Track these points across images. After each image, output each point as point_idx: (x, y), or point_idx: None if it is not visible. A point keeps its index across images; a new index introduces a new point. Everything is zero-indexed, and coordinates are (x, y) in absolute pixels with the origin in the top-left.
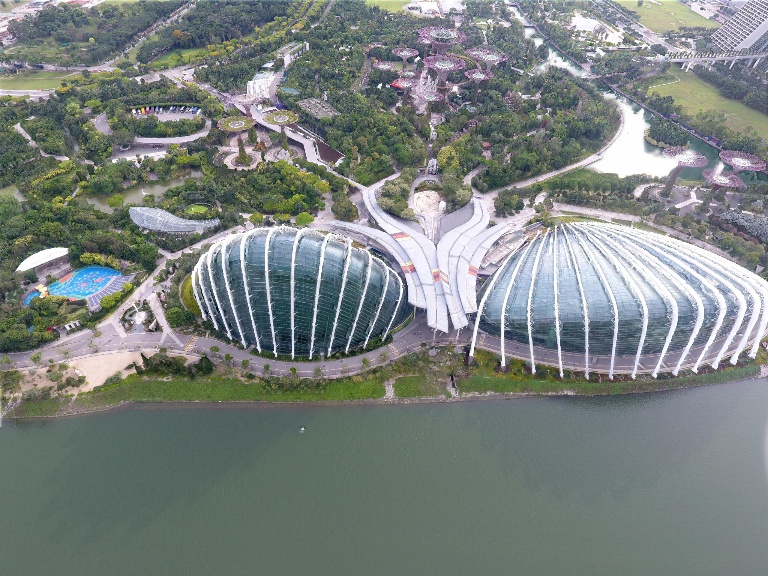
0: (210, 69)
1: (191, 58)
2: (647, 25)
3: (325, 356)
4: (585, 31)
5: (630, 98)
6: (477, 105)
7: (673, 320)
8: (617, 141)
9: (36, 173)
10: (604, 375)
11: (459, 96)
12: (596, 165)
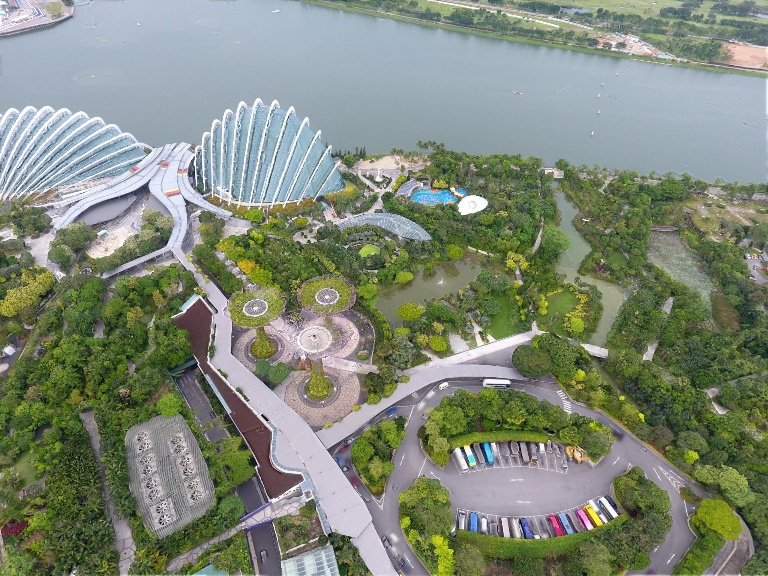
0: None
1: None
2: None
3: None
4: None
5: None
6: None
7: None
8: None
9: None
10: None
11: None
12: None
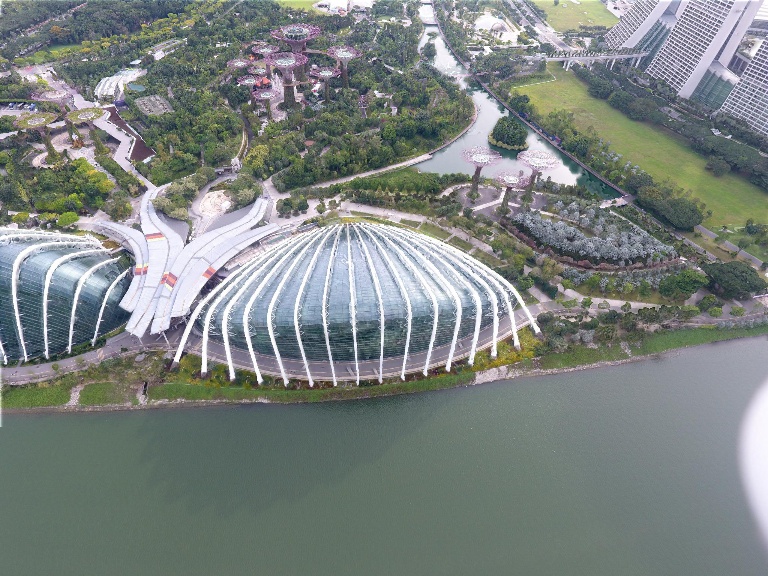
0: (66, 65)
1: (62, 54)
2: (553, 24)
3: (23, 361)
4: (481, 29)
5: (495, 97)
6: (331, 103)
7: (353, 325)
8: (459, 140)
9: None
10: (306, 382)
11: (316, 94)
12: (423, 165)
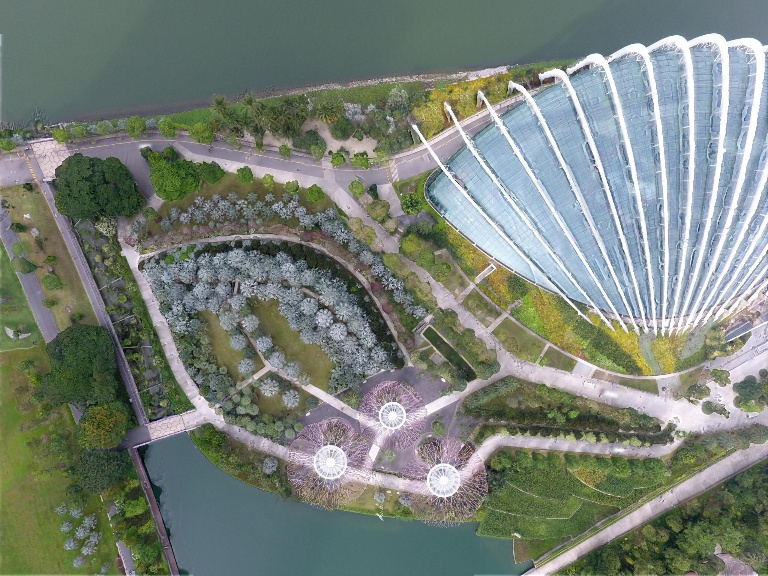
0: None
1: None
2: None
3: None
4: None
5: None
6: None
7: None
8: None
9: None
10: None
11: None
12: (503, 574)
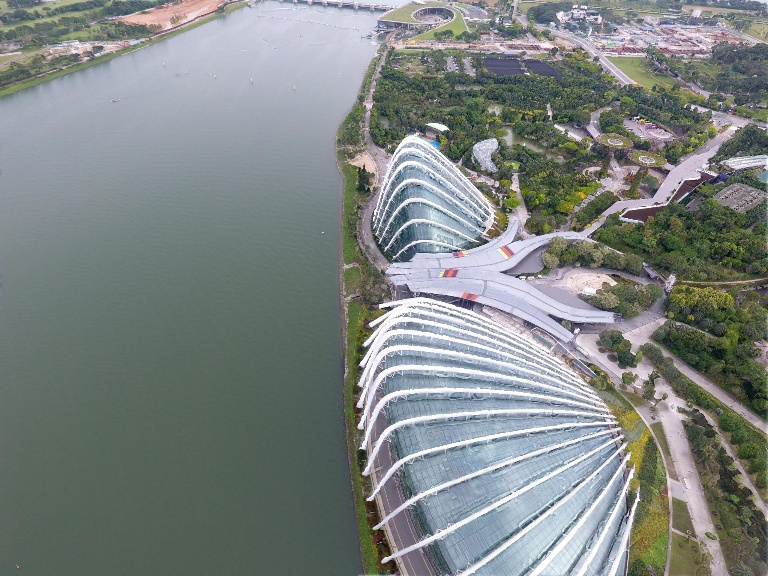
0: (755, 128)
1: None
2: None
3: None
4: None
5: None
6: None
7: None
8: None
9: (520, 106)
10: None
11: None
12: None
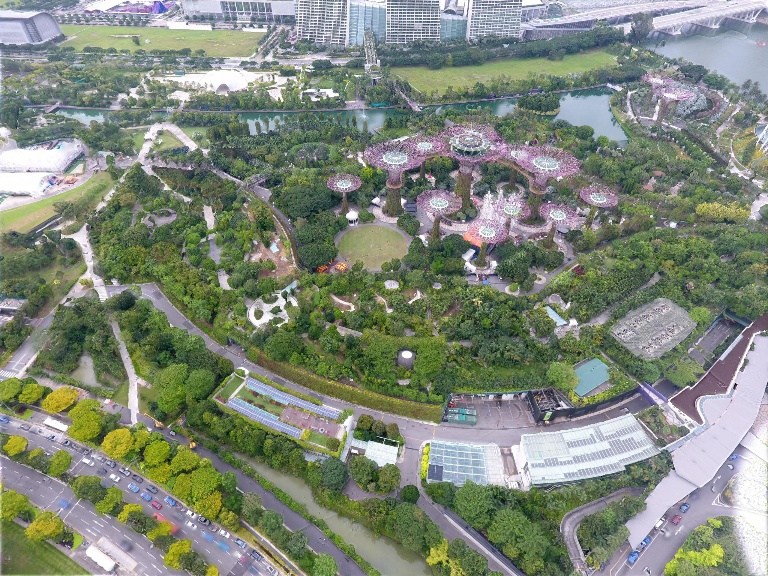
0: None
1: None
2: None
3: None
4: (251, 83)
5: (447, 104)
6: None
7: None
8: None
9: None
10: None
11: None
12: None
